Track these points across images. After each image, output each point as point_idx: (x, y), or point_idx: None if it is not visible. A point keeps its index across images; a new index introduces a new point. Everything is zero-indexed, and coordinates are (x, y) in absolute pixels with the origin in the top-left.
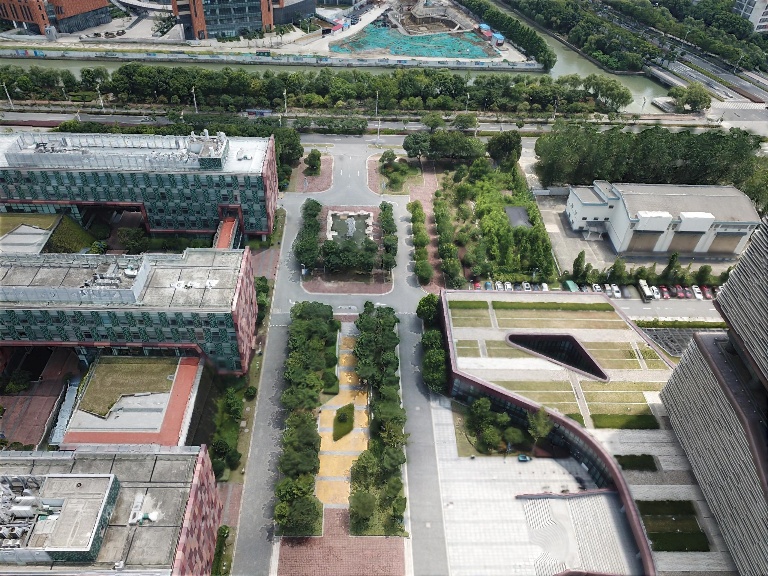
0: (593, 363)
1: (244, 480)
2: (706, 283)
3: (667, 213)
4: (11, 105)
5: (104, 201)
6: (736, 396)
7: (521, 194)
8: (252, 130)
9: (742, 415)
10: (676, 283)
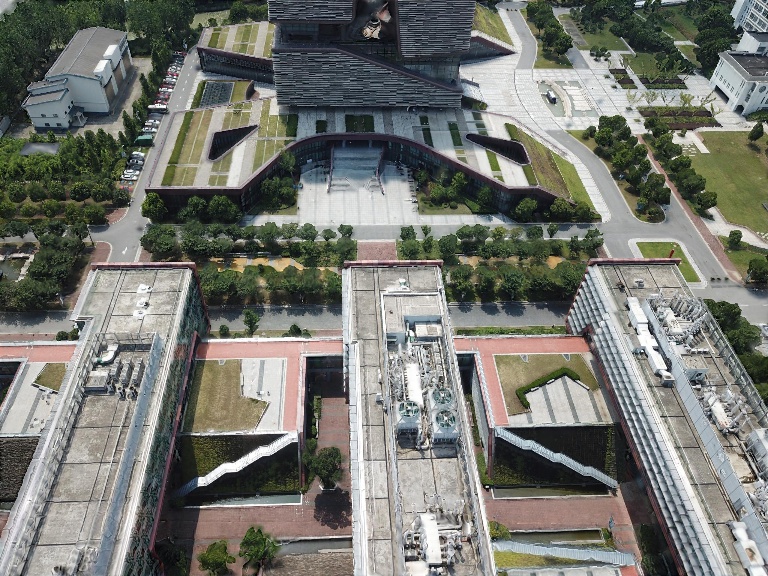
0: (242, 129)
1: (312, 330)
2: (160, 83)
3: (102, 61)
4: None
5: None
6: (321, 47)
7: (5, 141)
8: None
9: (333, 49)
10: (155, 95)
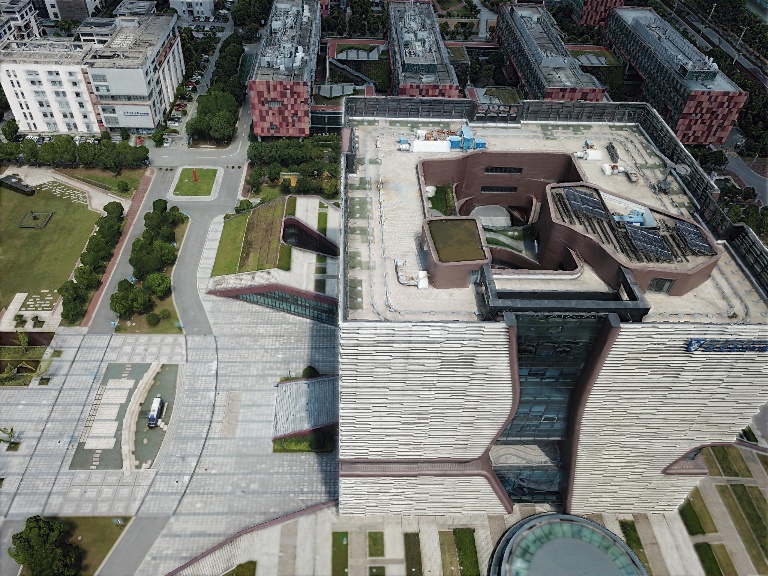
0: None
1: None
2: None
3: None
4: (738, 44)
5: (637, 67)
6: None
7: None
8: None
9: None
10: None
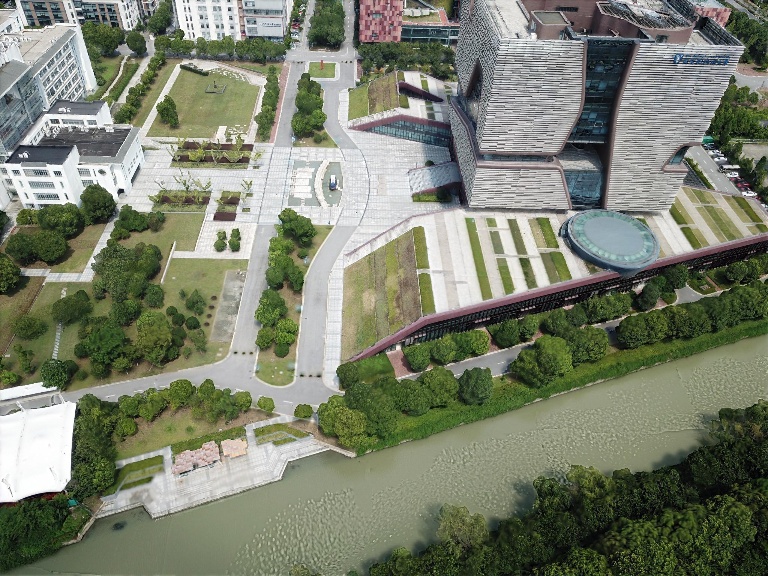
0: None
1: None
2: (763, 196)
3: None
4: None
5: None
6: None
7: None
8: (761, 29)
9: None
10: (751, 184)
